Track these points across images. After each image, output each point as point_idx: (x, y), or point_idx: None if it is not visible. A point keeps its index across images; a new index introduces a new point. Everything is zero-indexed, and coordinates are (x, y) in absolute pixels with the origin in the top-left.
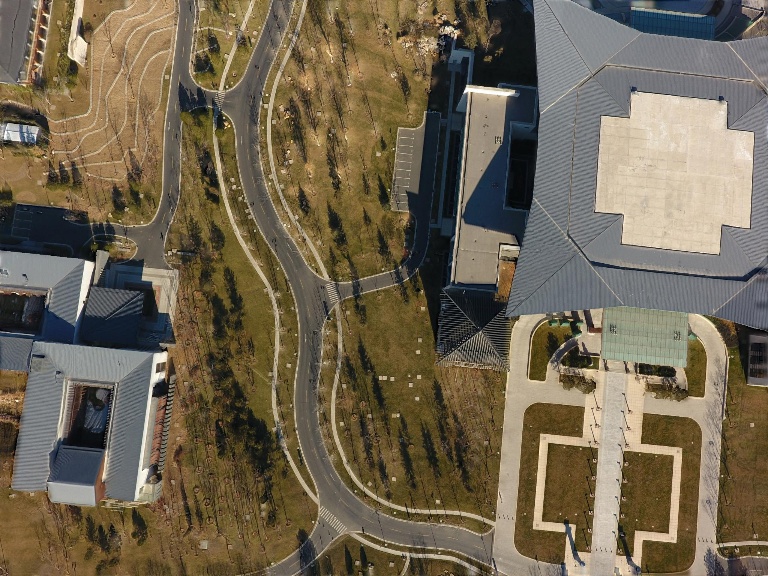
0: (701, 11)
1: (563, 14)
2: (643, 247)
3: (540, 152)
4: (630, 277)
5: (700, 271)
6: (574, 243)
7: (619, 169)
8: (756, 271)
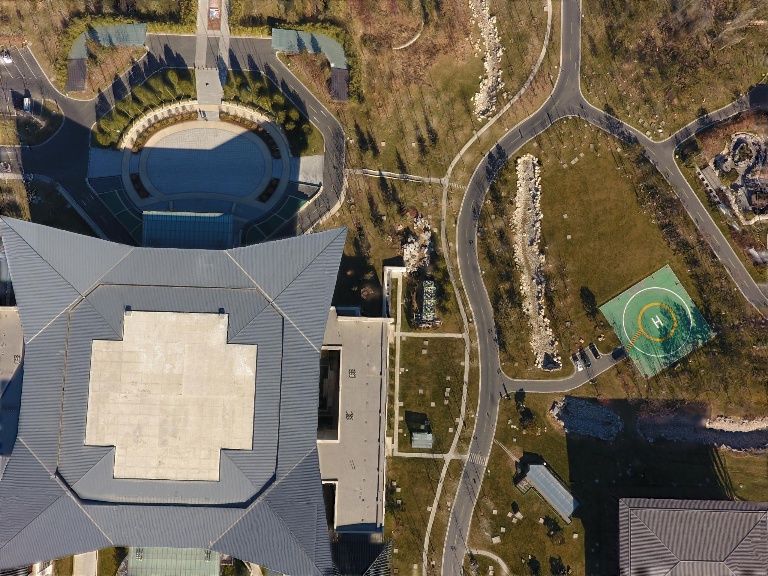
0: (255, 192)
1: (37, 241)
2: (137, 479)
3: (25, 386)
4: (122, 513)
5: (199, 500)
6: (62, 481)
7: (110, 397)
8: (257, 496)
